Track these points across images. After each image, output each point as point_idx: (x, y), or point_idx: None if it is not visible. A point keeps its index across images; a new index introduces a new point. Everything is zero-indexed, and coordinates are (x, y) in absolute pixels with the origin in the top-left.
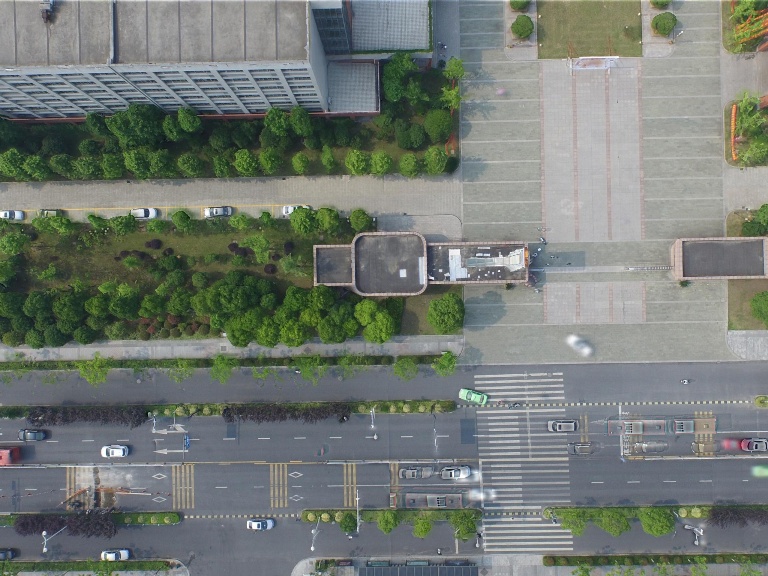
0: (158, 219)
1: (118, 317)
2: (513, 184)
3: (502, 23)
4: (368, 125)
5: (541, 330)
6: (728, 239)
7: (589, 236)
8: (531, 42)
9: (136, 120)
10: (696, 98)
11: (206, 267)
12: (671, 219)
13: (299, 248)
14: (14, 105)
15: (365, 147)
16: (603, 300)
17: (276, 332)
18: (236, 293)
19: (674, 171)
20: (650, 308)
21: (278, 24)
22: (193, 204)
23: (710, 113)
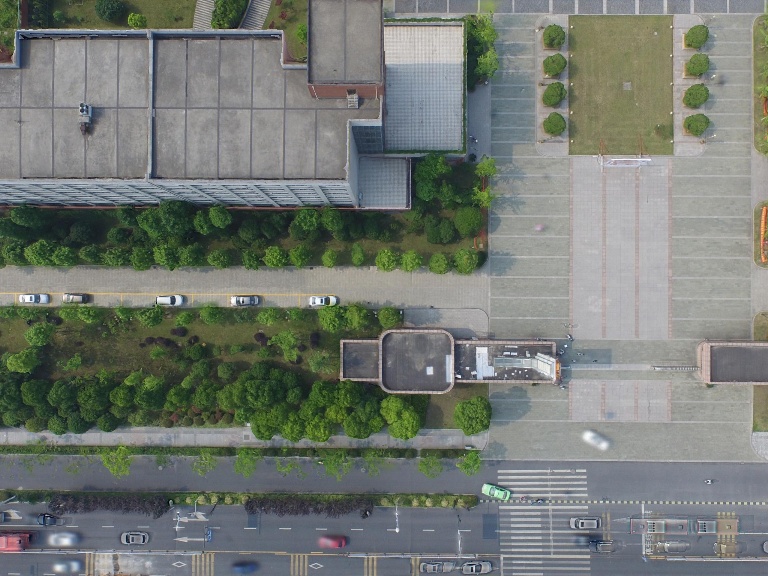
0: (184, 306)
1: (142, 407)
2: (541, 280)
3: (534, 118)
4: (397, 217)
5: (566, 426)
6: (756, 345)
7: (616, 334)
8: (562, 138)
9: (168, 219)
10: (726, 198)
11: (231, 356)
12: (698, 319)
13: (325, 339)
14: (45, 198)
15: (393, 239)
16: (628, 398)
17: (302, 429)
18: (263, 390)
19: (702, 271)
20: (675, 407)
21: (317, 142)
22: (219, 291)
23: (740, 213)
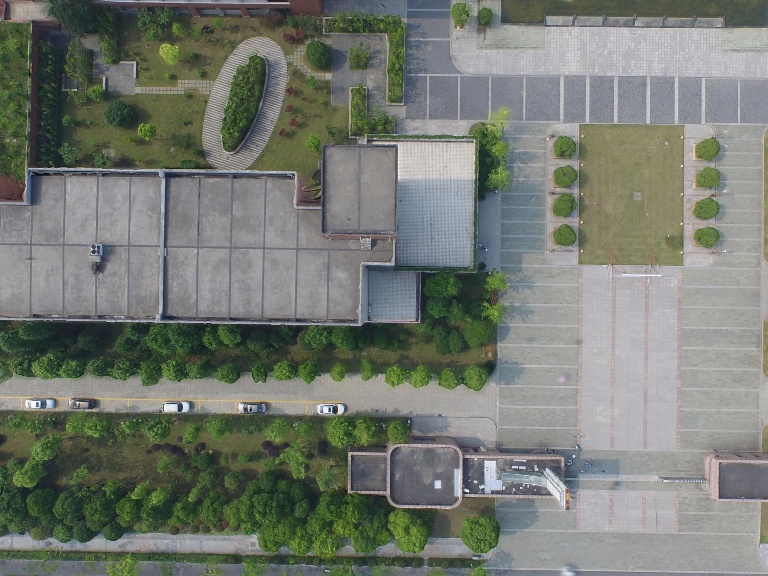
0: (191, 412)
1: None
2: (549, 389)
3: (544, 226)
4: (406, 325)
5: (573, 536)
6: (765, 462)
7: (624, 444)
8: (572, 247)
9: (177, 339)
10: (735, 309)
11: None
12: (707, 430)
13: (332, 447)
14: None
15: (402, 347)
16: (636, 509)
17: (309, 544)
18: (270, 507)
19: (711, 382)
20: (683, 518)
21: (330, 283)
22: (227, 398)
23: (749, 325)
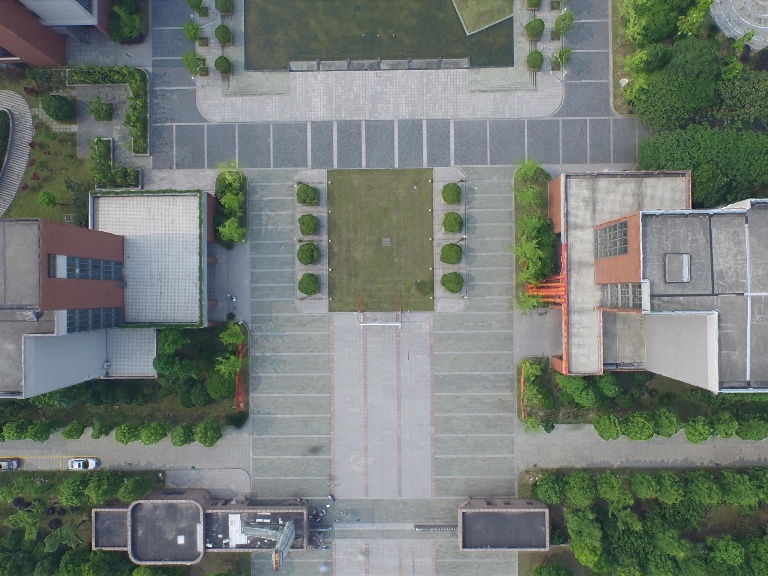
0: None
1: None
2: (303, 439)
3: (293, 274)
4: None
5: None
6: (508, 511)
7: (379, 493)
8: (322, 295)
9: None
10: (488, 354)
11: None
12: (462, 476)
13: None
14: None
15: (153, 399)
16: (392, 557)
17: None
18: (4, 568)
19: (465, 428)
20: (440, 566)
21: None
22: None
23: (502, 369)
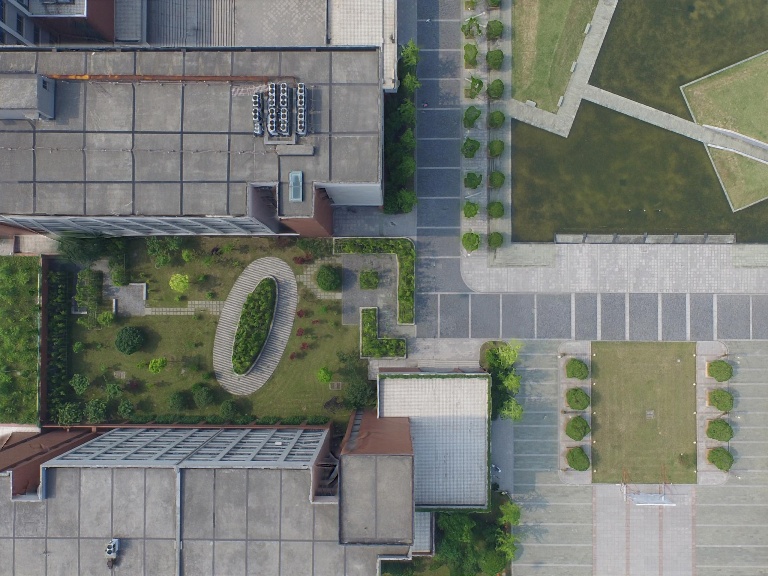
0: None
1: None
2: None
3: (556, 445)
4: None
5: None
6: None
7: None
8: None
9: None
10: (750, 527)
11: None
12: None
13: None
14: None
15: (416, 568)
16: None
17: None
18: None
19: None
20: None
21: (347, 575)
22: None
23: (763, 542)
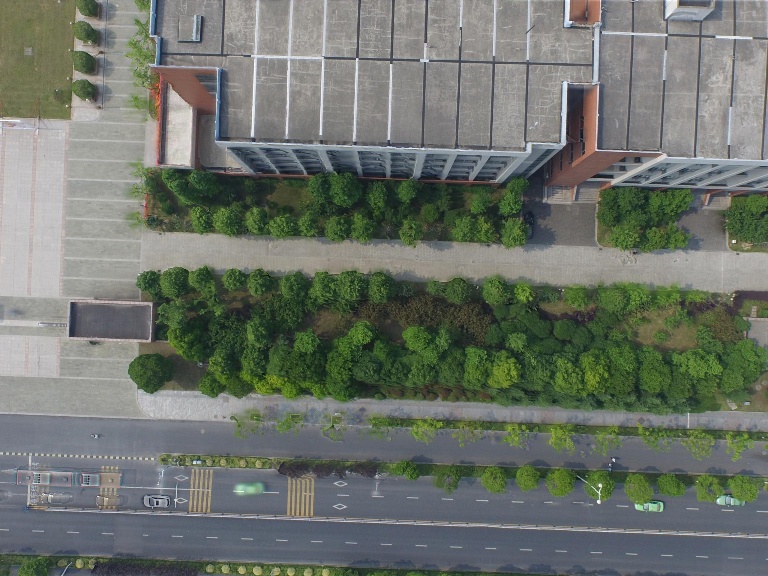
0: None
1: None
2: None
3: None
4: None
5: None
6: (114, 303)
7: (9, 290)
8: None
9: None
10: (120, 163)
11: None
12: (89, 278)
13: None
14: None
15: None
16: (19, 353)
17: None
18: None
19: (95, 232)
20: (64, 363)
21: None
22: None
23: (133, 178)
